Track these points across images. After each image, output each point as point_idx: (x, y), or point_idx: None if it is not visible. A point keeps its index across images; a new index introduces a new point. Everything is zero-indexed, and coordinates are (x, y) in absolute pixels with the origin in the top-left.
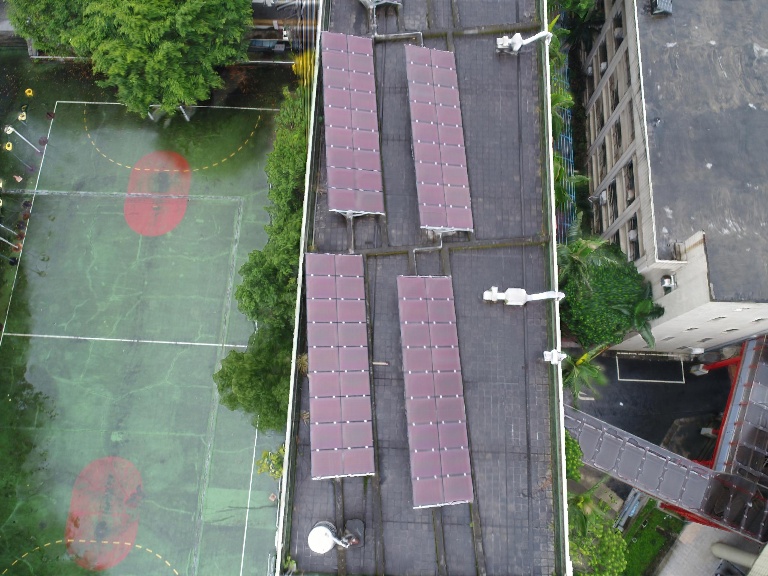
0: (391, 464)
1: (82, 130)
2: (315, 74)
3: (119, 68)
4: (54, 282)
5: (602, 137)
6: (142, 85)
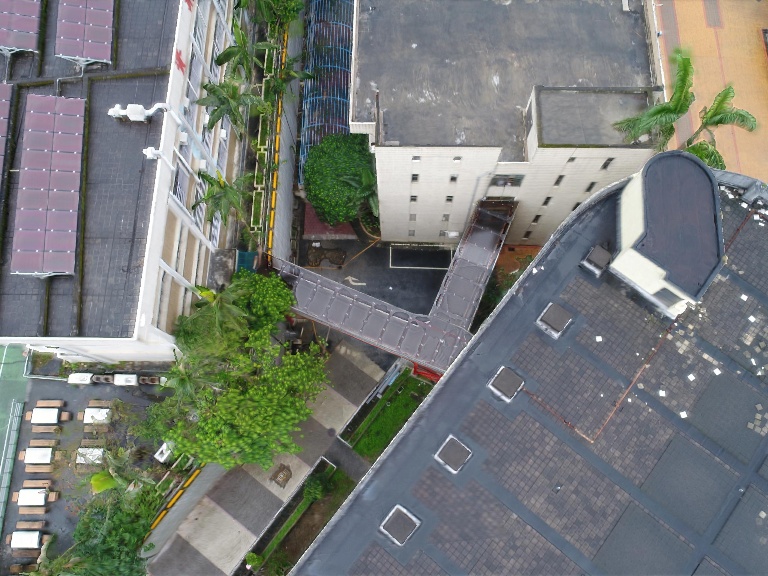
0: None
1: None
2: None
3: None
4: None
5: None
6: None
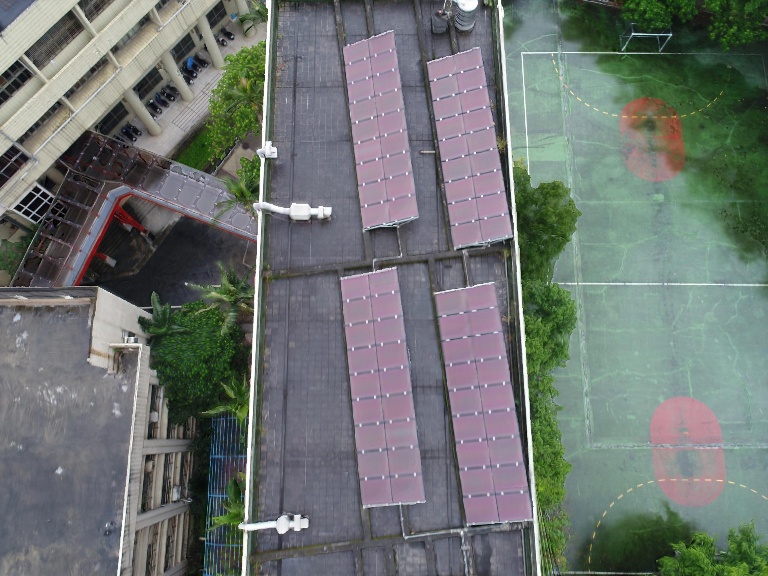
0: (413, 75)
1: None
2: None
3: None
4: None
5: (167, 574)
6: None
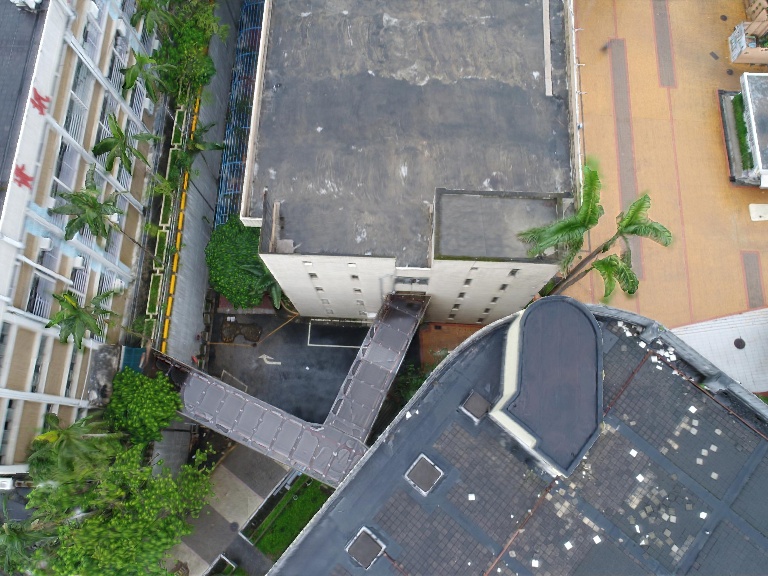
0: None
1: None
2: None
3: None
4: None
5: None
6: None
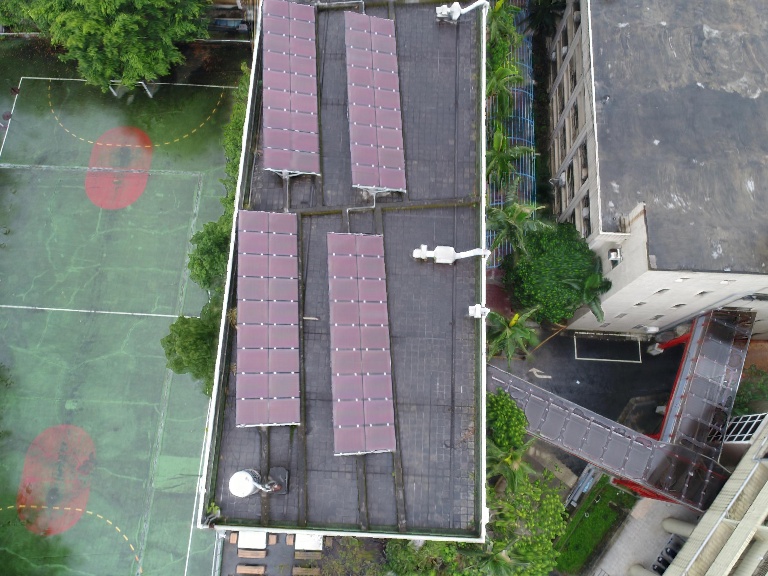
0: (318, 415)
1: (46, 105)
2: (256, 39)
3: (77, 40)
4: (13, 253)
5: (562, 120)
6: (102, 59)
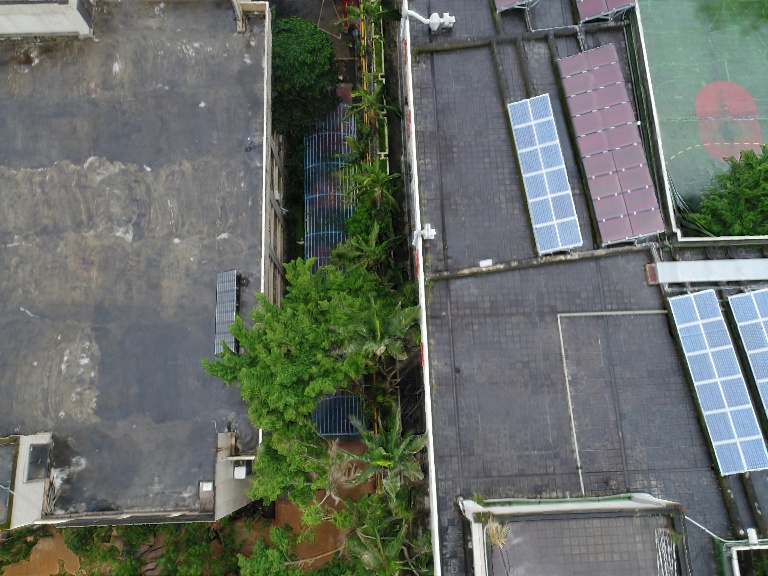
0: None
1: None
2: None
3: None
4: None
5: None
6: None
